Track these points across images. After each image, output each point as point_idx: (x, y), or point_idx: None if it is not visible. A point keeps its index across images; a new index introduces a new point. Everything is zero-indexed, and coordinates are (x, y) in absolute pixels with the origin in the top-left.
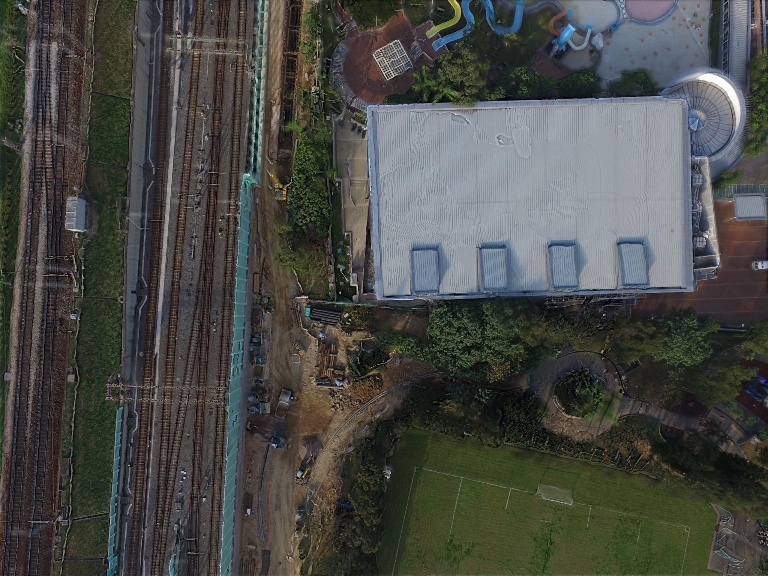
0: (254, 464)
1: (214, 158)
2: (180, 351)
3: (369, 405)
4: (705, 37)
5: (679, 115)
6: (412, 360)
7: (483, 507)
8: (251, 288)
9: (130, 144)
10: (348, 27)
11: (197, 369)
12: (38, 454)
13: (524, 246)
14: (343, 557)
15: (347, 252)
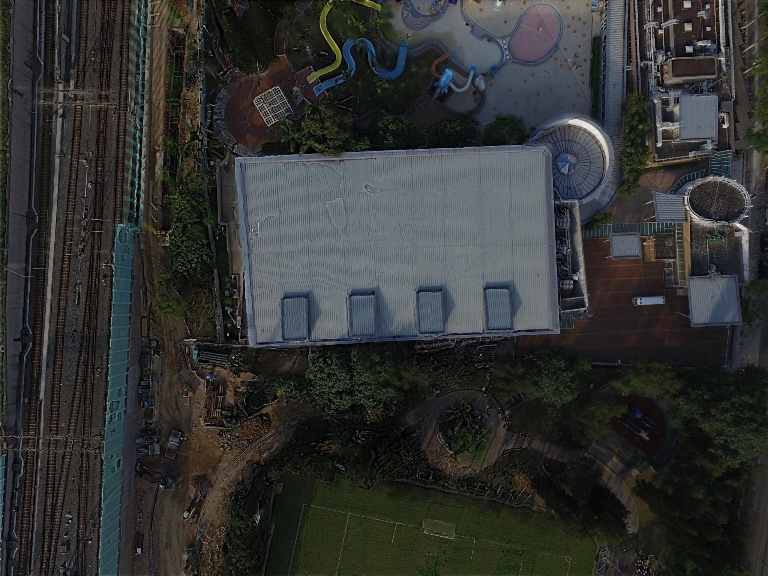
0: (145, 504)
1: (97, 205)
2: (65, 397)
3: (257, 444)
4: (586, 77)
5: (542, 163)
6: None
7: (370, 542)
8: (138, 332)
9: (7, 196)
10: (231, 73)
11: (82, 414)
12: None
13: (392, 293)
14: None
15: (234, 295)
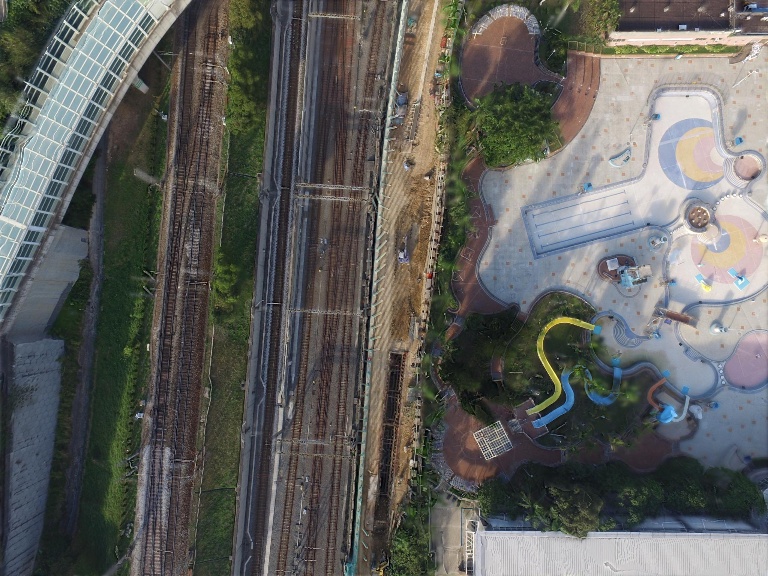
0: None
1: (312, 533)
2: None
3: None
4: None
5: None
6: None
7: None
8: None
9: (234, 539)
10: (447, 397)
11: None
12: None
13: None
14: None
15: None
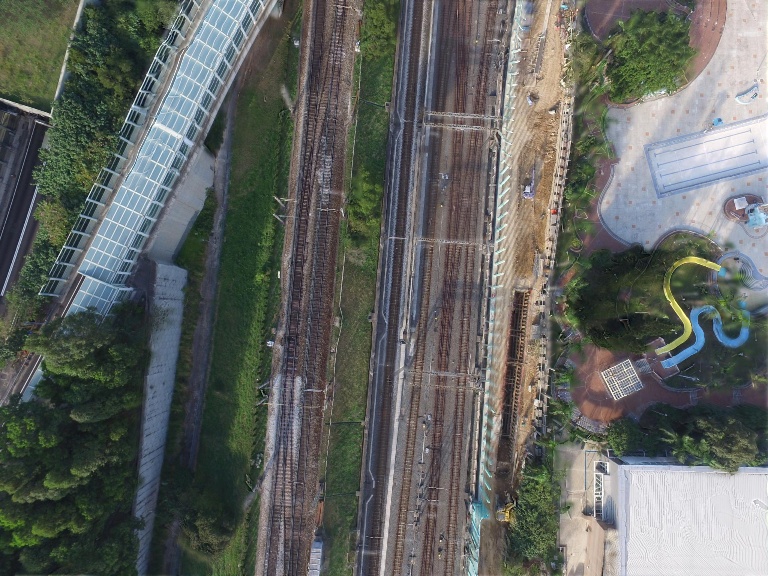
0: None
1: (435, 472)
2: None
3: None
4: None
5: None
6: None
7: None
8: None
9: (362, 473)
10: (572, 336)
11: None
12: None
13: None
14: None
15: (562, 568)
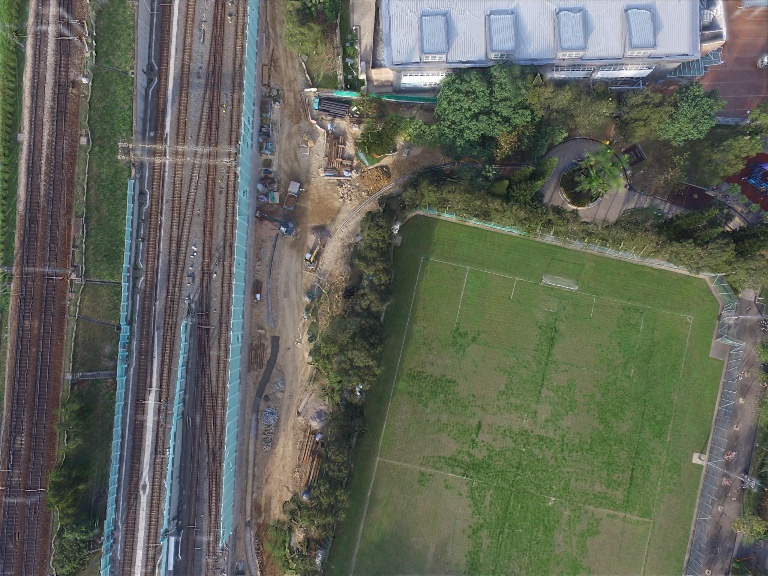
0: (263, 253)
1: None
2: (190, 132)
3: (377, 196)
4: None
5: None
6: (419, 153)
7: (489, 297)
8: (260, 78)
9: None
10: None
11: None
12: (51, 212)
13: (532, 12)
14: (352, 320)
15: (355, 45)
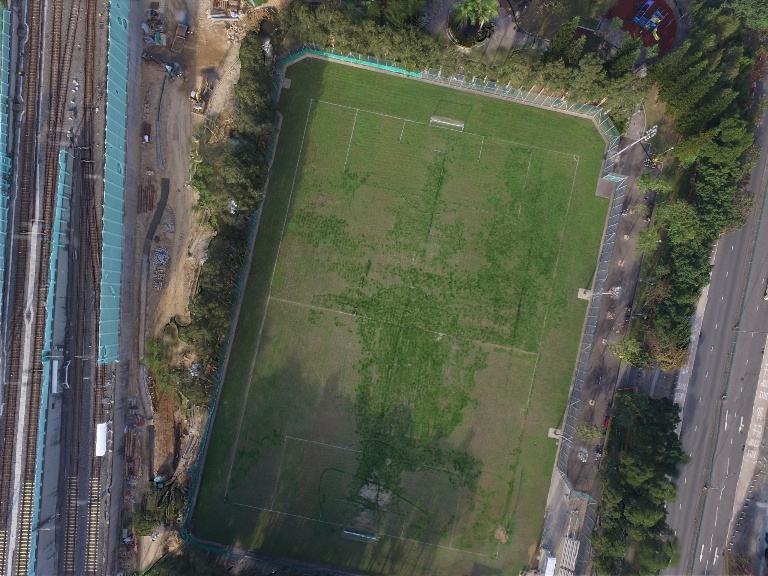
0: (151, 95)
1: None
2: None
3: None
4: None
5: None
6: None
7: (378, 138)
8: None
9: None
10: None
11: None
12: None
13: None
14: (229, 145)
15: None
